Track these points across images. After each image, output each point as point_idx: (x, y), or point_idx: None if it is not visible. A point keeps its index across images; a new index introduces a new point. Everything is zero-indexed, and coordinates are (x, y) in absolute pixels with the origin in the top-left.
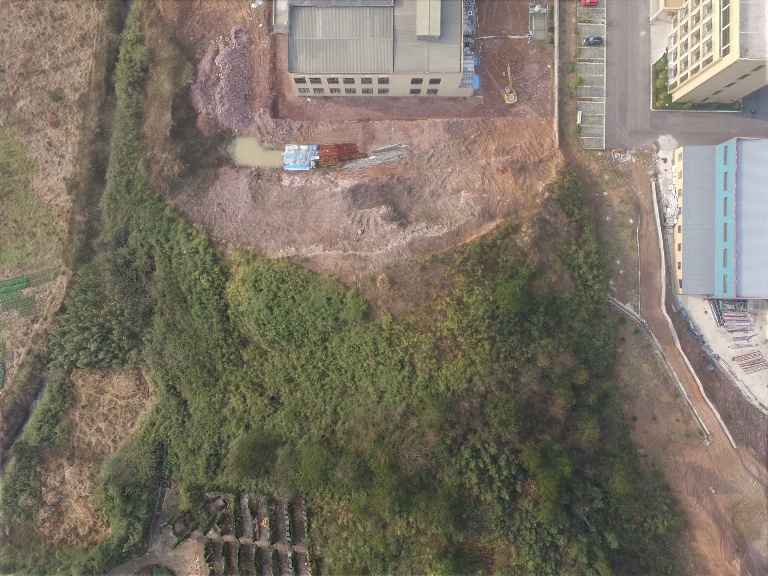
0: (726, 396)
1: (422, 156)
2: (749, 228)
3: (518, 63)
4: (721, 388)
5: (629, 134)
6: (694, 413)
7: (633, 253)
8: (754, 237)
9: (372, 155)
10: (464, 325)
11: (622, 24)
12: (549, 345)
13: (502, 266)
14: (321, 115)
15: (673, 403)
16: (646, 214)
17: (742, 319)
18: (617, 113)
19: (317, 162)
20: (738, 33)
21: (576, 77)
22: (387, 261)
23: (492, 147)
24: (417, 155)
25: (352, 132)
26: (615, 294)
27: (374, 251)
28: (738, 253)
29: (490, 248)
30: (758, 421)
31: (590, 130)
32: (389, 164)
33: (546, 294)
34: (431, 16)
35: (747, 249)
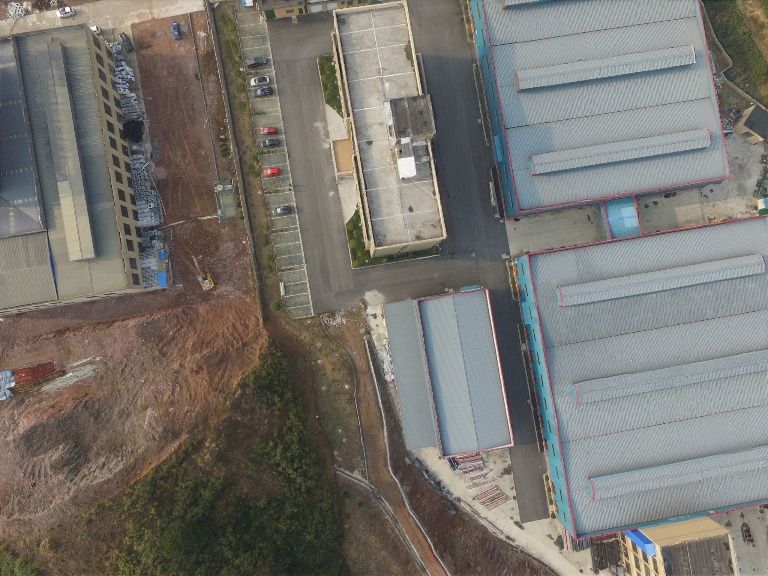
0: (467, 541)
1: (116, 368)
2: (446, 385)
3: (211, 245)
4: (463, 532)
5: (335, 296)
6: (427, 575)
7: (353, 419)
8: (452, 394)
9: (69, 372)
10: (137, 575)
11: (309, 188)
12: (245, 562)
13: (180, 495)
14: (17, 333)
15: (402, 572)
16: (363, 375)
17: (475, 458)
18: (320, 277)
19: (13, 389)
20: (369, 224)
21: (272, 249)
22: (51, 522)
23: (190, 343)
24: (111, 367)
25: (46, 350)
26: (341, 464)
27: (38, 512)
28: (440, 411)
29: (166, 479)
30: (507, 555)
31: (296, 299)
32: (85, 381)
33: (232, 512)
34: (81, 239)
35: (448, 406)
